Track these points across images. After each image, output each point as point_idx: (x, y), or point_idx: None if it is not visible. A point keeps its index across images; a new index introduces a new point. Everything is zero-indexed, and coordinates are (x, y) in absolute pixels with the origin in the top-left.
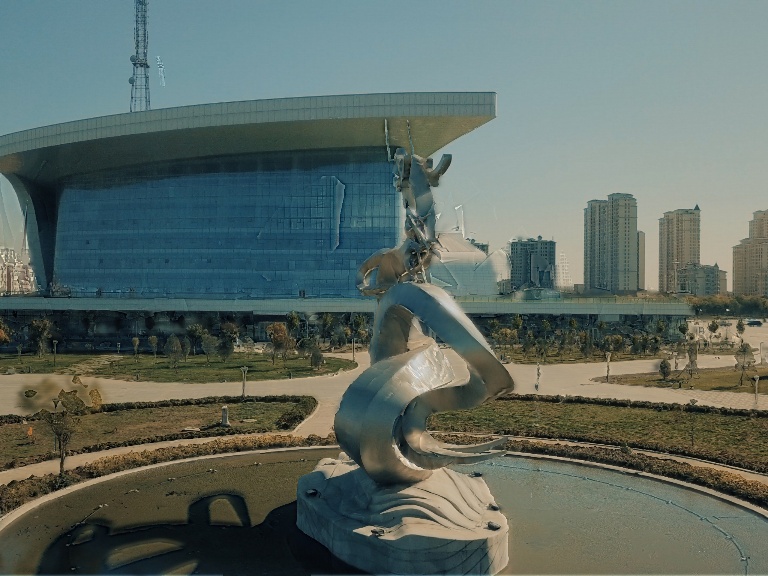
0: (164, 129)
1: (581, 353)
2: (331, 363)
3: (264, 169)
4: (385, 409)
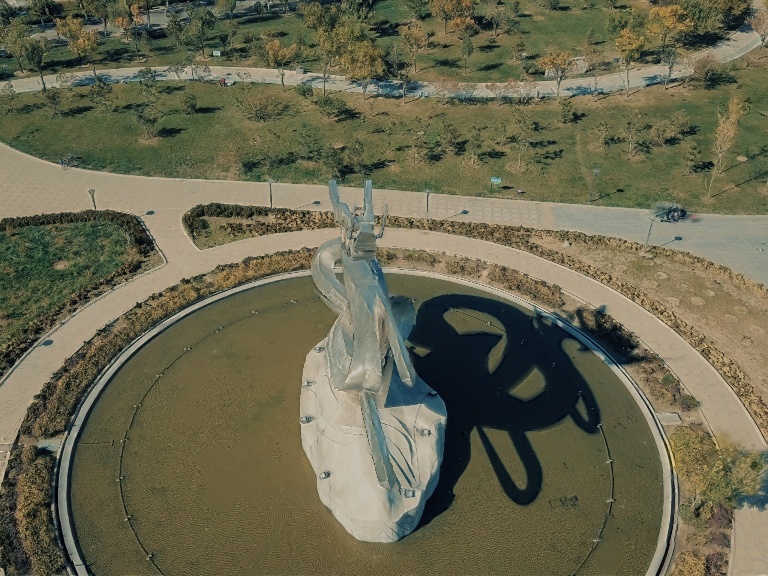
0: None
1: None
2: None
3: None
4: None
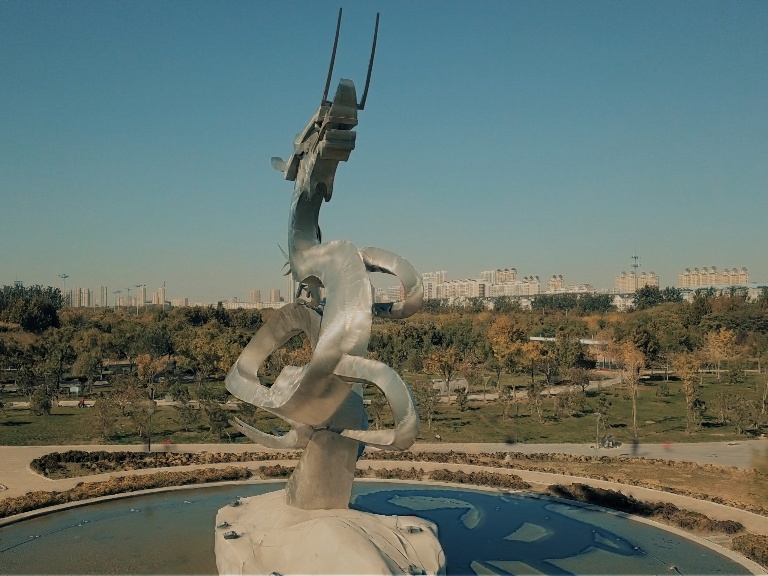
0: None
1: None
2: None
3: None
4: None
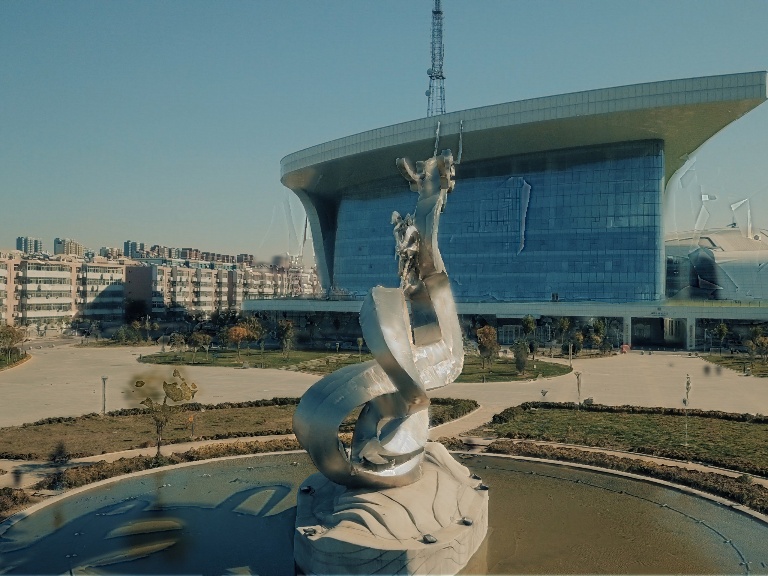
0: (418, 139)
1: None
2: (544, 369)
3: (518, 172)
4: (333, 412)
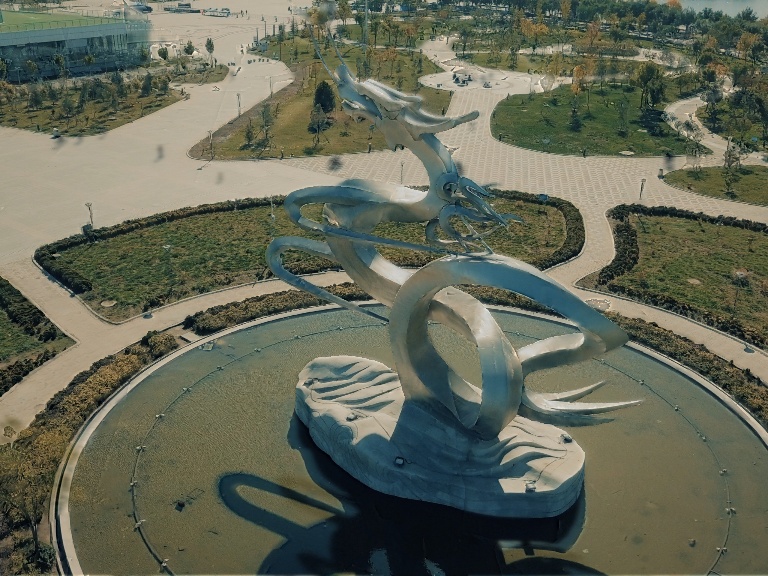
0: None
1: (94, 101)
2: None
3: None
4: (515, 387)
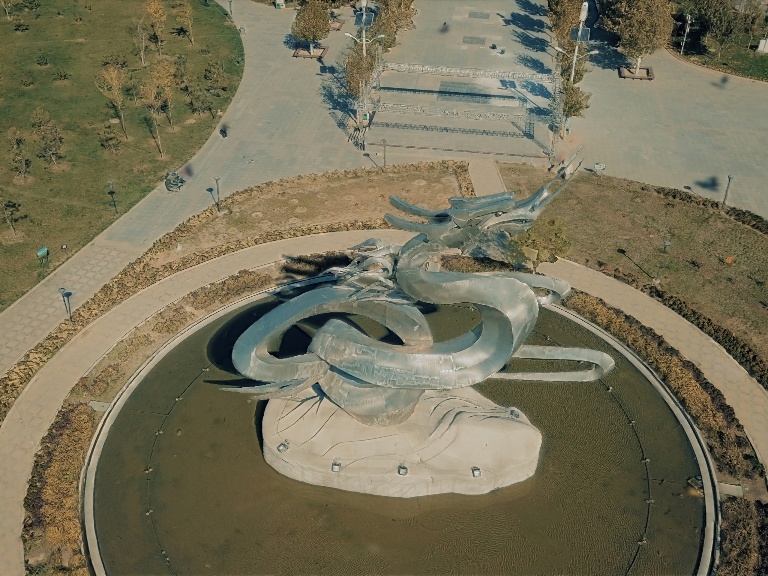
0: None
1: None
2: None
3: None
4: None
